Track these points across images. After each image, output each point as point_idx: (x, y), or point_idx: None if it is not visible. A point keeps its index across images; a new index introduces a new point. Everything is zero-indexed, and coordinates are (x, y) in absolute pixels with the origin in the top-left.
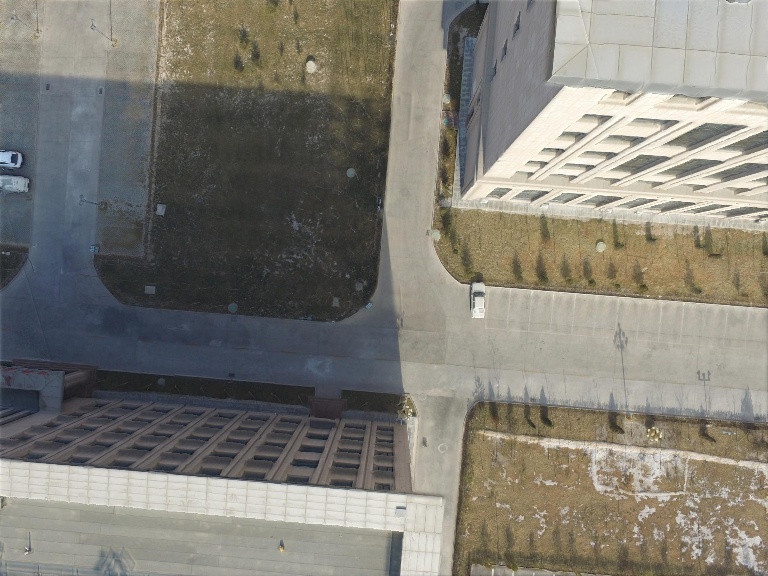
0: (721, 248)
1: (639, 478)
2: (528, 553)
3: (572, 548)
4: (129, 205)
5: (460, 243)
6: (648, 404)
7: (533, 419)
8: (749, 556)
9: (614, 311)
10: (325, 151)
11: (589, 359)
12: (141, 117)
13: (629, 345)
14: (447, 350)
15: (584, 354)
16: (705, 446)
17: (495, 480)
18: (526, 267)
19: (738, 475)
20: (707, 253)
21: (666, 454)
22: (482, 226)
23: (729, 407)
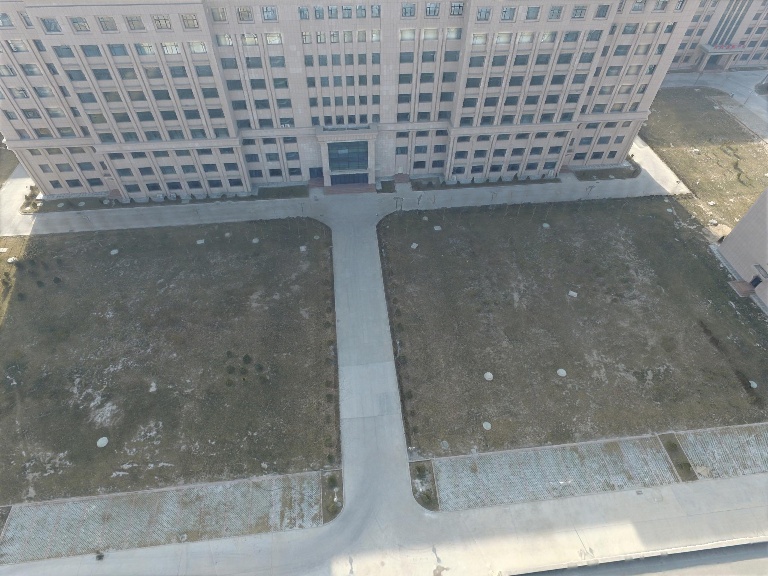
0: None
1: None
2: None
3: None
4: (731, 107)
5: None
6: None
7: None
8: None
9: None
10: (663, 129)
11: None
12: (756, 129)
13: None
14: None
15: None
16: None
17: None
18: None
19: None
20: None
21: None
22: None
23: None
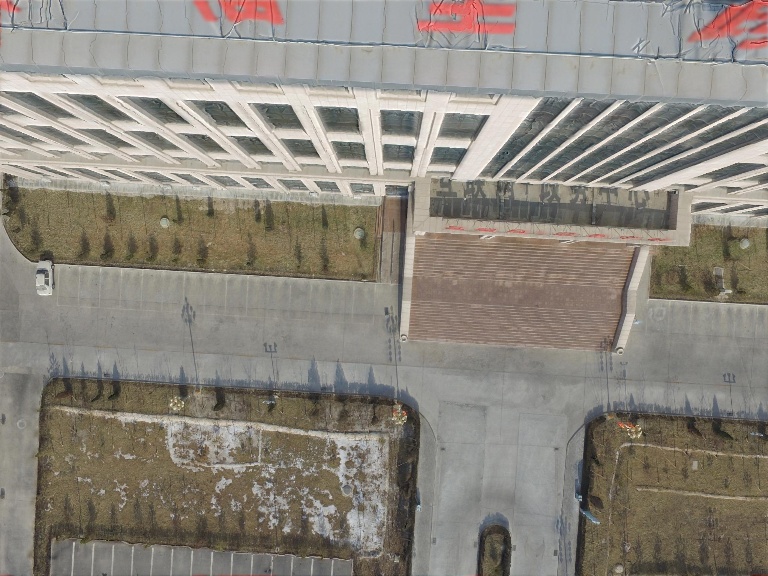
0: (282, 221)
1: (214, 450)
2: (109, 526)
3: (152, 520)
4: None
5: (29, 222)
6: (218, 377)
7: (107, 394)
8: (325, 525)
9: (181, 286)
10: None
11: (159, 334)
12: None
13: (197, 319)
14: (21, 328)
15: (153, 329)
16: (275, 417)
17: (76, 455)
18: (94, 244)
19: (311, 445)
20: (268, 226)
21: (240, 426)
22: (50, 205)
23: (296, 378)
